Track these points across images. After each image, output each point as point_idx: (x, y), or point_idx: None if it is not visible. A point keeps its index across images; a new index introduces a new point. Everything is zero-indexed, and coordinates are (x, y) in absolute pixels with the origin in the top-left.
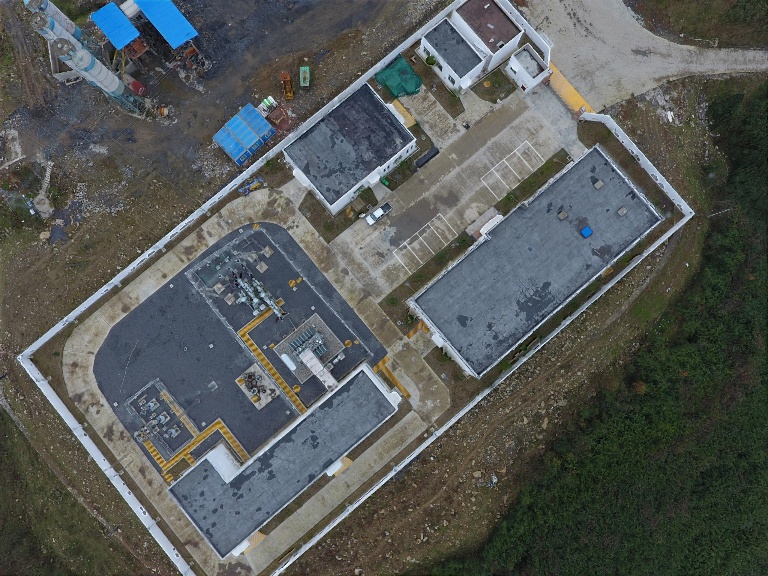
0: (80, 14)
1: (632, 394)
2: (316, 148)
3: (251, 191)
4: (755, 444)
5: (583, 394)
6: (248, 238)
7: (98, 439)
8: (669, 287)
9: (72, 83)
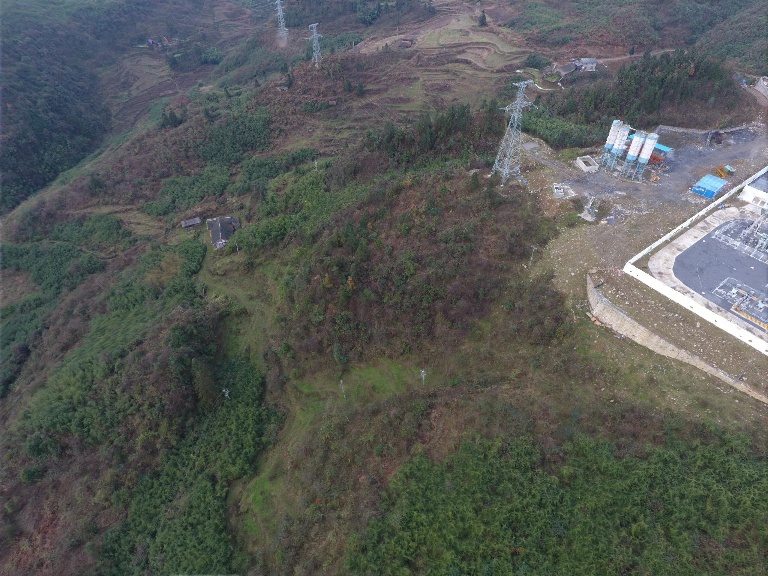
0: (582, 155)
1: None
2: (764, 186)
3: (726, 208)
4: None
5: None
6: (738, 225)
7: None
8: None
9: (594, 172)
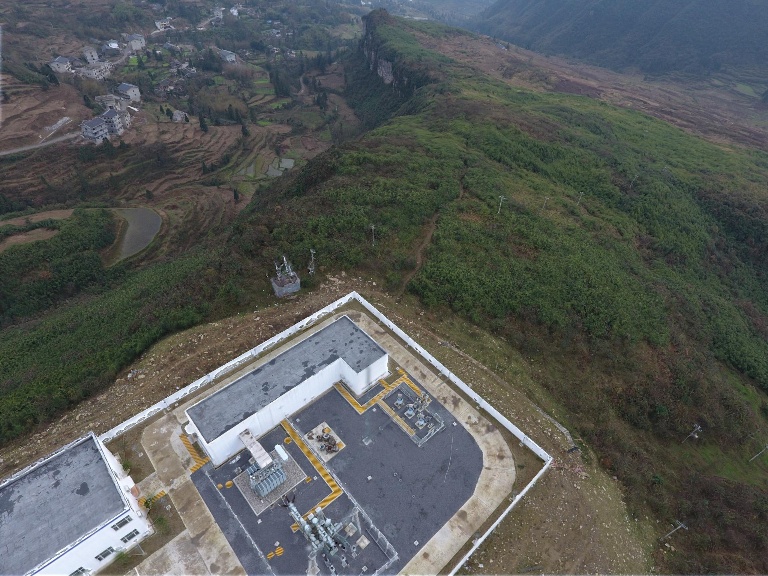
0: None
1: None
2: None
3: None
4: None
5: None
6: None
7: (465, 397)
8: None
9: None
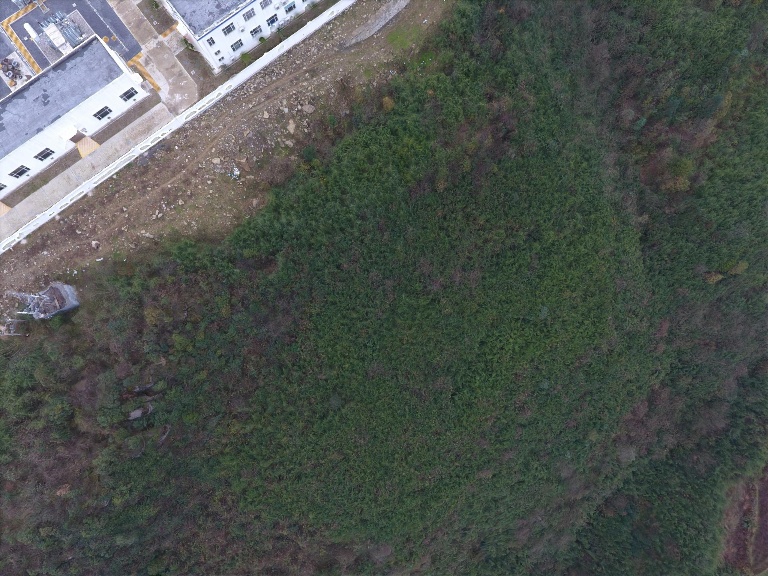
0: None
1: (382, 112)
2: None
3: None
4: (545, 223)
5: (333, 107)
6: None
7: None
8: (426, 19)
9: None
